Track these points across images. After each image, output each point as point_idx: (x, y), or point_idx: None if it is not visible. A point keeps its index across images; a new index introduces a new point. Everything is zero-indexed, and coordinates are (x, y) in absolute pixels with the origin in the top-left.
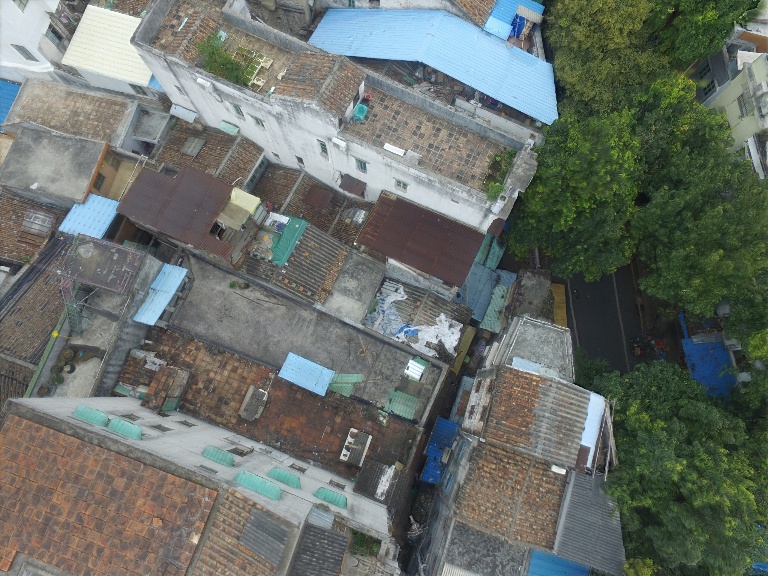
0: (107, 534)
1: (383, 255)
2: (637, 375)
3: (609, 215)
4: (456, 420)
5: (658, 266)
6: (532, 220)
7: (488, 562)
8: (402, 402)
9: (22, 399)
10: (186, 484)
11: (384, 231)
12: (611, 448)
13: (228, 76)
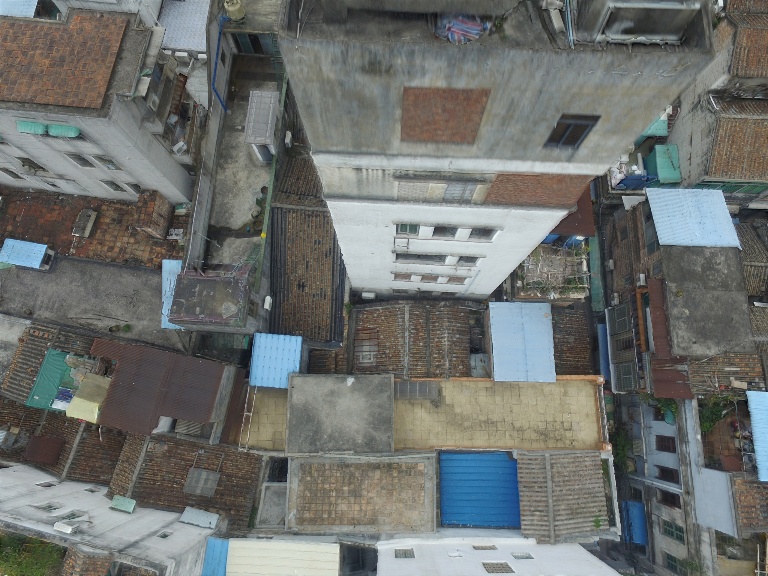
0: (1, 50)
1: None
2: None
3: None
4: None
5: None
6: None
7: None
8: None
9: (111, 126)
10: None
11: None
12: None
13: (7, 536)
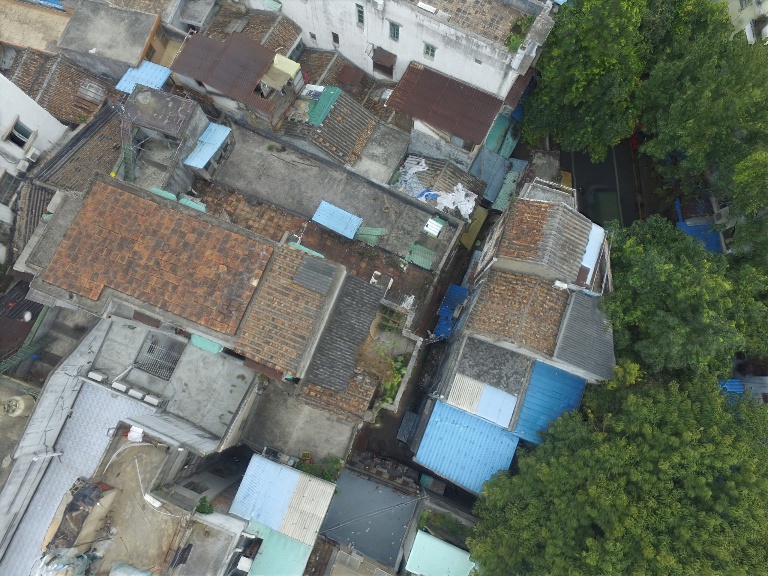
0: (180, 276)
1: (409, 120)
2: (634, 226)
3: (616, 78)
4: (467, 287)
5: (658, 130)
6: (545, 97)
7: (494, 374)
8: (421, 254)
9: None
10: (247, 241)
11: (412, 96)
12: (608, 278)
13: None
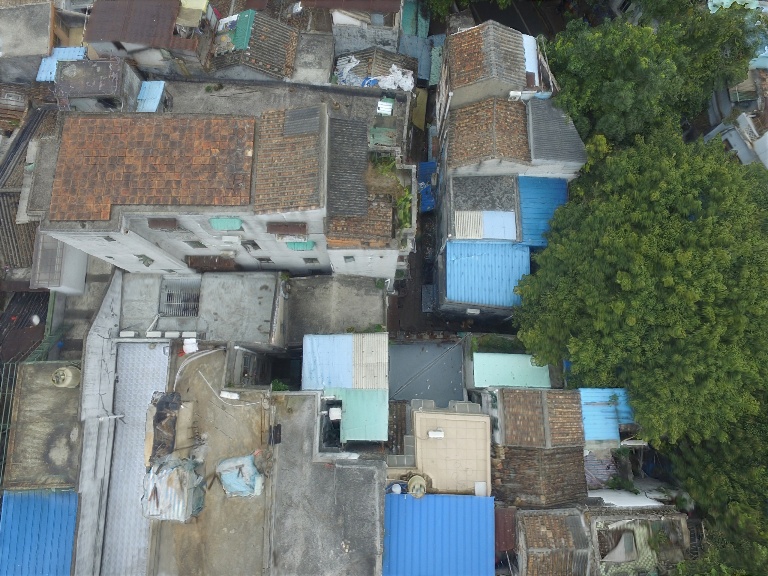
0: (179, 171)
1: (327, 17)
2: (558, 37)
3: None
4: (434, 161)
5: None
6: None
7: (488, 200)
8: (383, 135)
9: None
10: (228, 122)
11: None
12: None
13: None
